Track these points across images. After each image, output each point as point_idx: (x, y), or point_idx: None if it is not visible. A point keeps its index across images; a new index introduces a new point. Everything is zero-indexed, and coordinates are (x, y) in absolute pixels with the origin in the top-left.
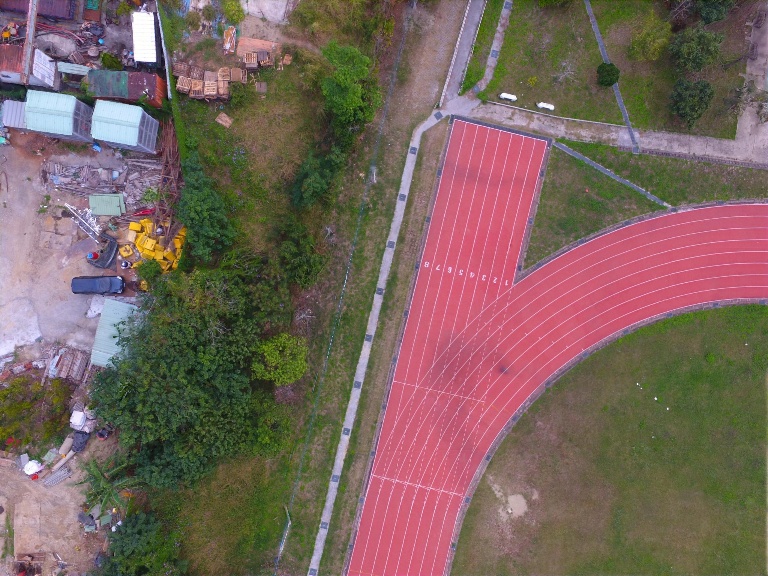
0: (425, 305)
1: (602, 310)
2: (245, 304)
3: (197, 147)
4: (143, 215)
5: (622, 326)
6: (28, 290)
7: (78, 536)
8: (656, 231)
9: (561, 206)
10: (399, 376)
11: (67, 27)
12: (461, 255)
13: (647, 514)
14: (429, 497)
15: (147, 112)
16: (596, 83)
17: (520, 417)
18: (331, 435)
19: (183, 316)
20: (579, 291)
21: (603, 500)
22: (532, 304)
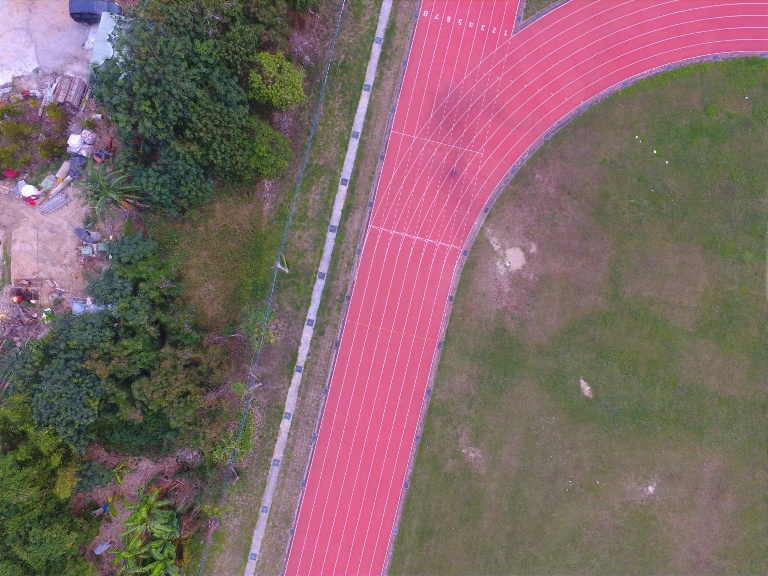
0: (424, 55)
1: (602, 62)
2: (243, 11)
3: None
4: None
5: (622, 78)
6: (26, 21)
7: (75, 264)
8: None
9: None
10: (397, 126)
11: None
12: (460, 4)
13: (645, 268)
14: (427, 249)
15: None
16: None
17: (518, 169)
18: (329, 184)
19: None
20: (579, 42)
21: (601, 254)
22: (531, 55)
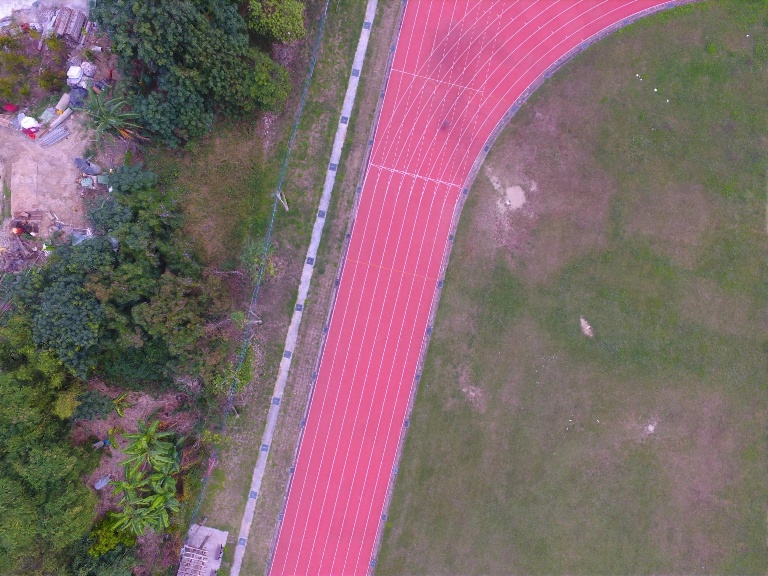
0: None
1: None
2: None
3: None
4: None
5: (622, 16)
6: None
7: (75, 197)
8: None
9: None
10: (397, 64)
11: None
12: None
13: (646, 207)
14: (427, 188)
15: None
16: None
17: (519, 108)
18: (329, 122)
19: None
20: None
21: (602, 192)
22: None
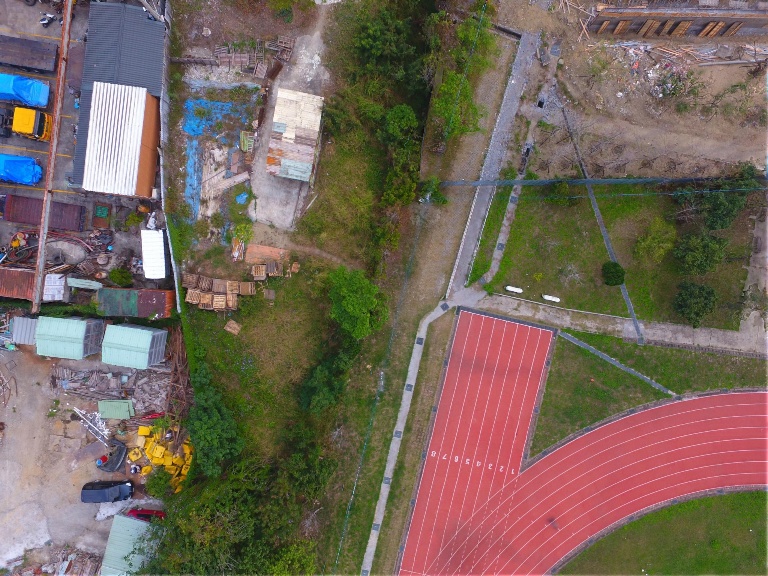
0: (432, 494)
1: (608, 497)
2: (254, 525)
3: (206, 354)
4: (152, 418)
5: (627, 513)
6: (37, 493)
7: None
8: (661, 419)
9: (567, 395)
10: (406, 564)
11: (76, 234)
12: (468, 444)
13: None
14: None
15: (156, 325)
16: (601, 276)
17: None
18: None
19: (194, 557)
20: (585, 479)
21: None
22: (538, 492)
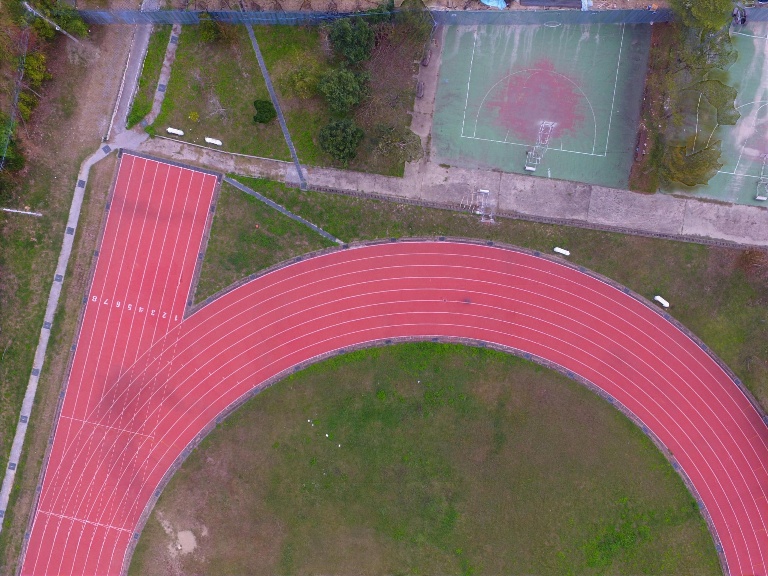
0: (93, 339)
1: (273, 346)
2: None
3: None
4: None
5: (294, 362)
6: None
7: None
8: (328, 267)
9: (232, 241)
10: (66, 411)
11: None
12: (130, 290)
13: (318, 551)
14: (97, 533)
15: None
16: None
17: (190, 453)
18: None
19: None
20: (250, 327)
21: (273, 537)
22: (202, 339)
